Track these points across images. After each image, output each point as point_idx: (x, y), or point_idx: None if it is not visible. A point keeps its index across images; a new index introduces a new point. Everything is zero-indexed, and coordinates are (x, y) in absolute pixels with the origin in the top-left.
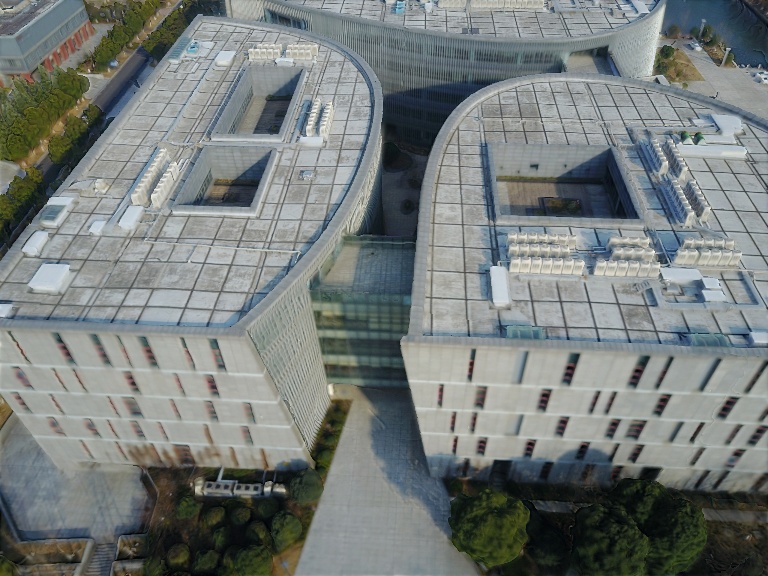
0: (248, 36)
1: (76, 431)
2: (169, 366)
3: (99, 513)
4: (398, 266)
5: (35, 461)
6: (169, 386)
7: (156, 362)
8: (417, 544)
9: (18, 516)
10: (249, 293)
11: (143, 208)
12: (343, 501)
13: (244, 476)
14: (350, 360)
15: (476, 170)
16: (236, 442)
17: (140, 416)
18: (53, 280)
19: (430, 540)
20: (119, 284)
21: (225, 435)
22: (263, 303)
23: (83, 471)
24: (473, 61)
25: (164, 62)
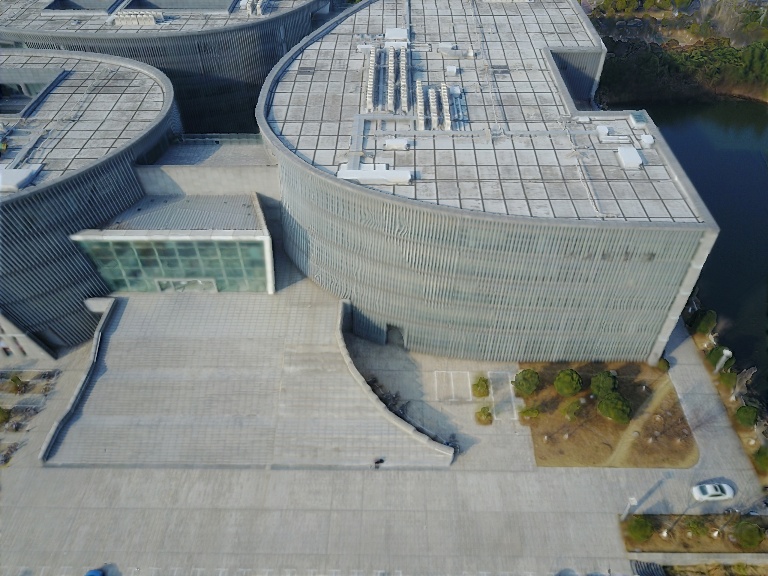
0: None
1: None
2: None
3: None
4: None
5: None
6: None
7: None
8: None
9: None
10: None
11: None
12: None
13: None
14: None
15: None
16: None
17: None
18: None
19: None
20: None
21: None
22: None
23: None
24: None
25: None
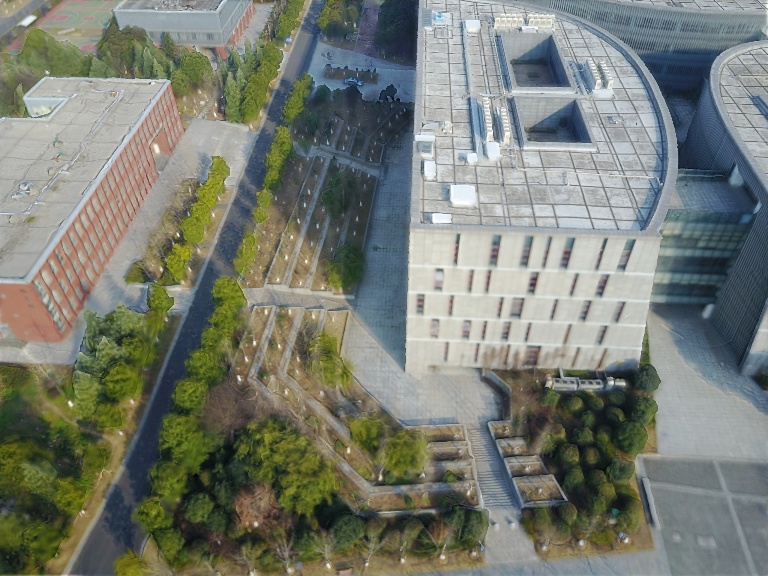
0: (475, 8)
1: (450, 333)
2: (576, 267)
3: (458, 406)
4: (715, 194)
5: (382, 367)
6: (564, 286)
7: (567, 263)
8: (750, 425)
9: (389, 409)
10: (634, 208)
11: (498, 144)
12: (673, 393)
13: (579, 375)
14: (664, 277)
15: (759, 116)
16: (587, 342)
17: (515, 317)
18: (470, 196)
19: (759, 422)
20: (520, 201)
21: (582, 335)
22: (659, 213)
23: (427, 375)
24: (679, 32)
25: (422, 29)
